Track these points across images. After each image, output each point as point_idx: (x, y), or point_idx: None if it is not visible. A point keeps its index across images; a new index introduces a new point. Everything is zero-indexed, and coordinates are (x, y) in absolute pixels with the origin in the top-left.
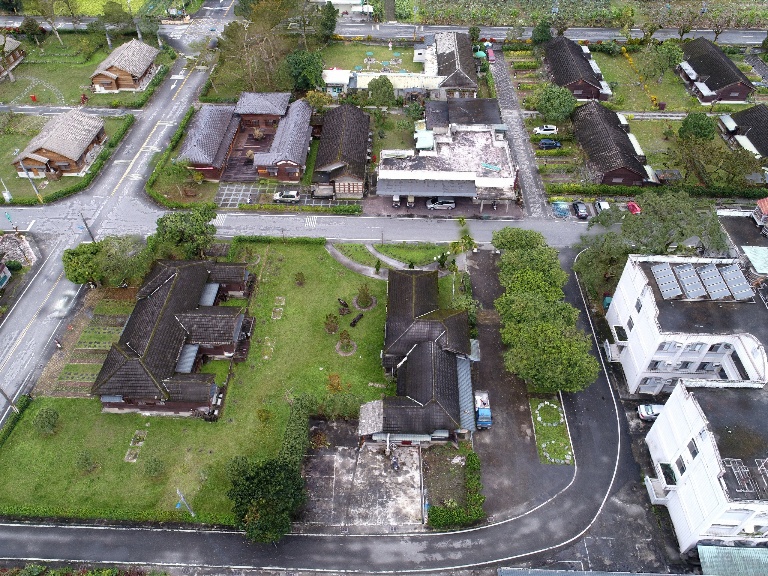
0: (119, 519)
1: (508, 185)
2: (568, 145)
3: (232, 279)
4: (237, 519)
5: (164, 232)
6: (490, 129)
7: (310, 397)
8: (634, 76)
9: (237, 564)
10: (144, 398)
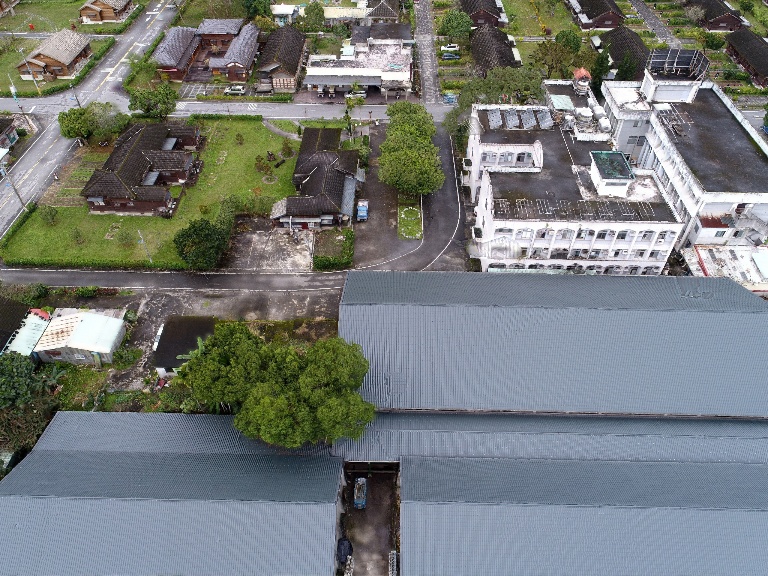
0: (100, 266)
1: (407, 78)
2: (466, 58)
3: (186, 134)
4: (179, 251)
5: (135, 102)
6: (400, 43)
7: (237, 197)
8: (533, 12)
9: (180, 287)
10: (118, 197)
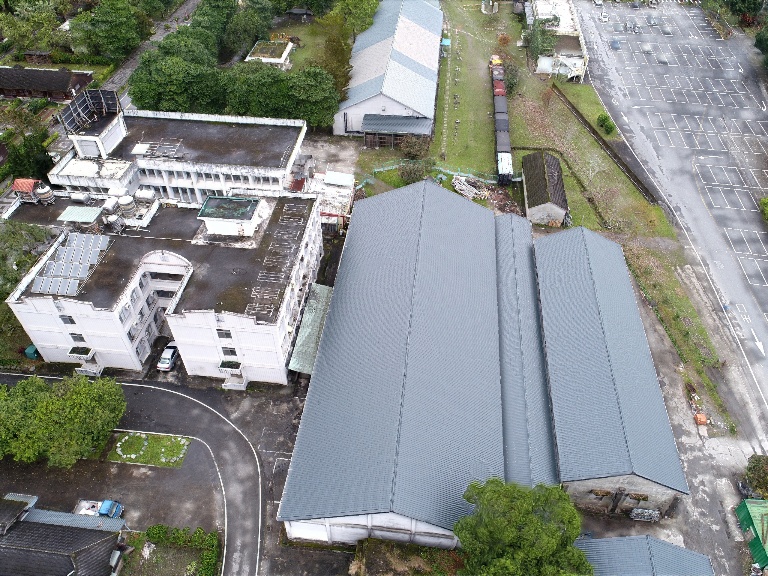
0: None
1: None
2: None
3: None
4: None
5: None
6: None
7: None
8: None
9: None
10: None
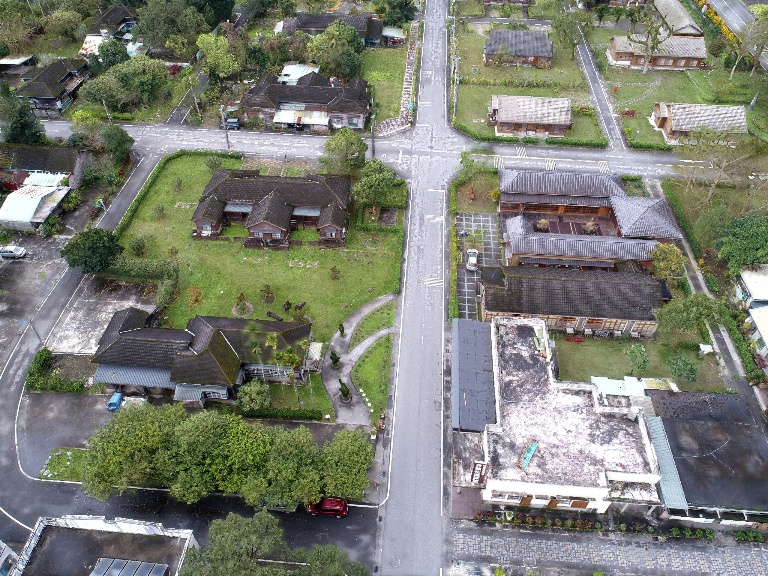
0: None
1: None
2: None
3: (321, 220)
4: None
5: None
6: None
7: (172, 271)
8: None
9: None
10: None
